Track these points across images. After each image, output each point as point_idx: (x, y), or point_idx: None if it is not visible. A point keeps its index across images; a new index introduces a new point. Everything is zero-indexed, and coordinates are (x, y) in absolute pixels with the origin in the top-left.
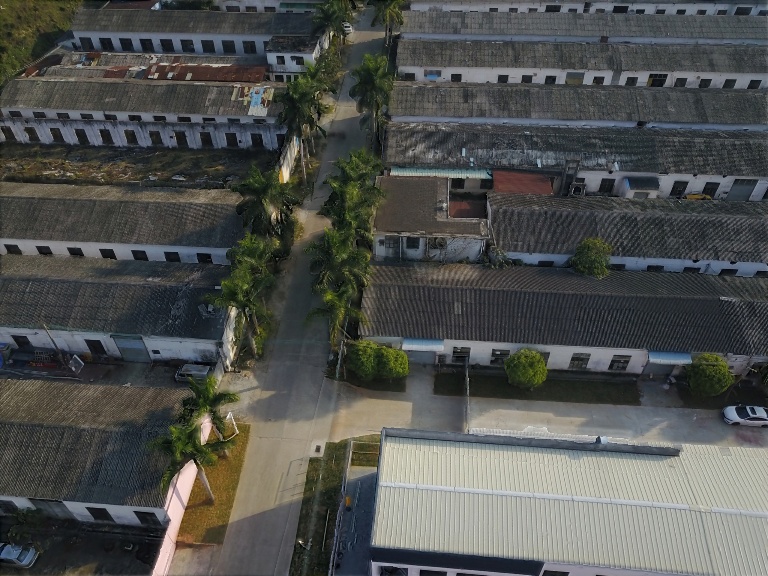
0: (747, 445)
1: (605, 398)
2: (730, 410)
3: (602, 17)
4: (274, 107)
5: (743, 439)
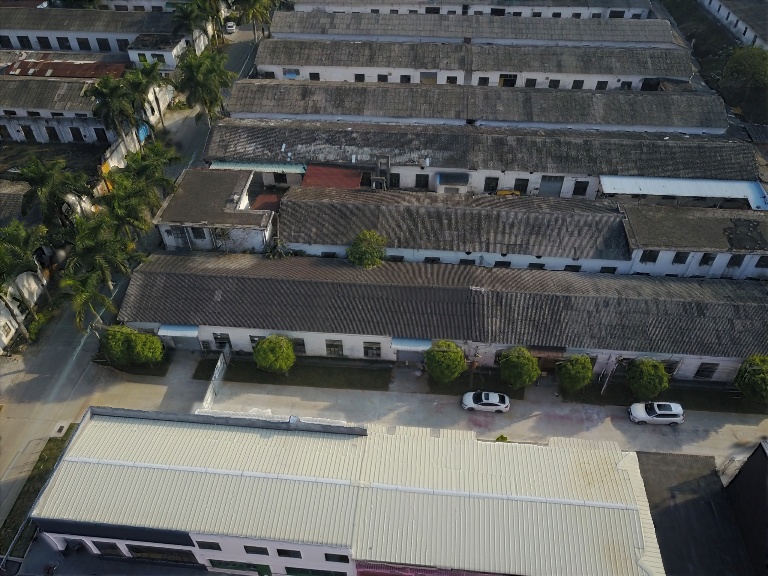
0: (476, 429)
1: (356, 384)
2: (468, 396)
3: (467, 19)
4: None
5: (474, 423)
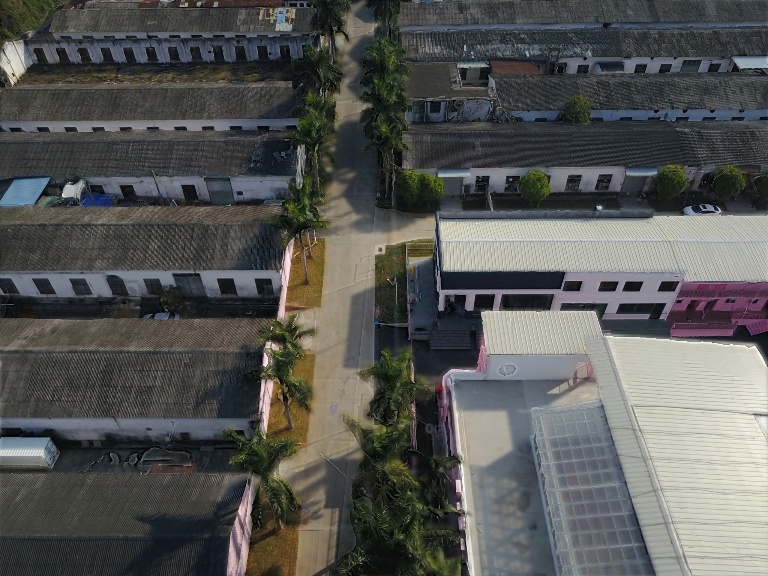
0: None
1: None
2: (687, 209)
3: None
4: (297, 24)
5: None
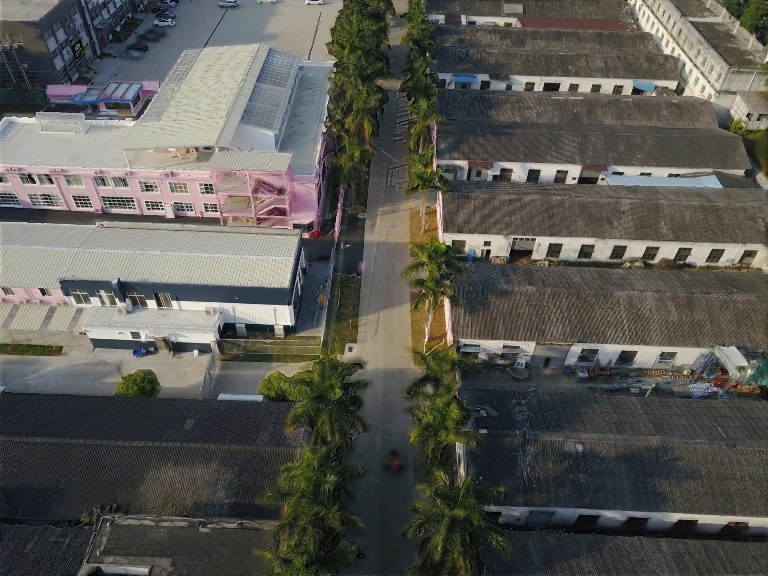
0: None
1: None
2: None
3: None
4: None
5: None
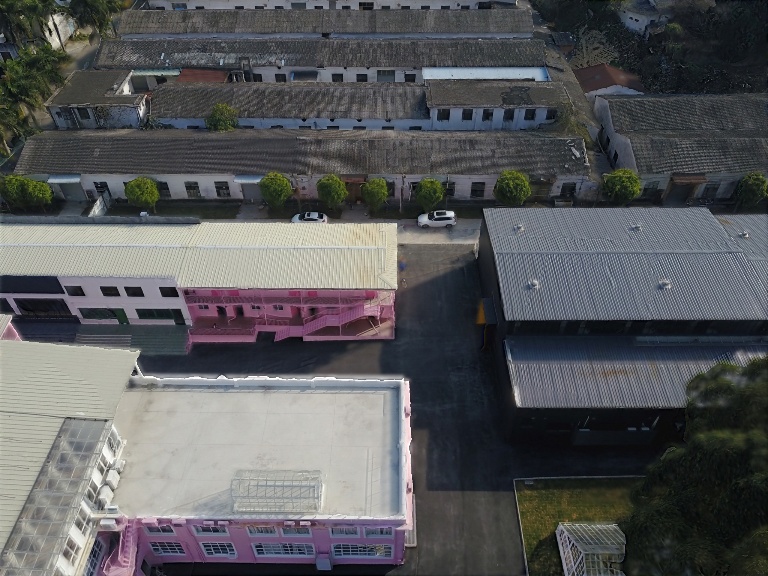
0: None
1: (210, 215)
2: (296, 216)
3: None
4: None
5: None
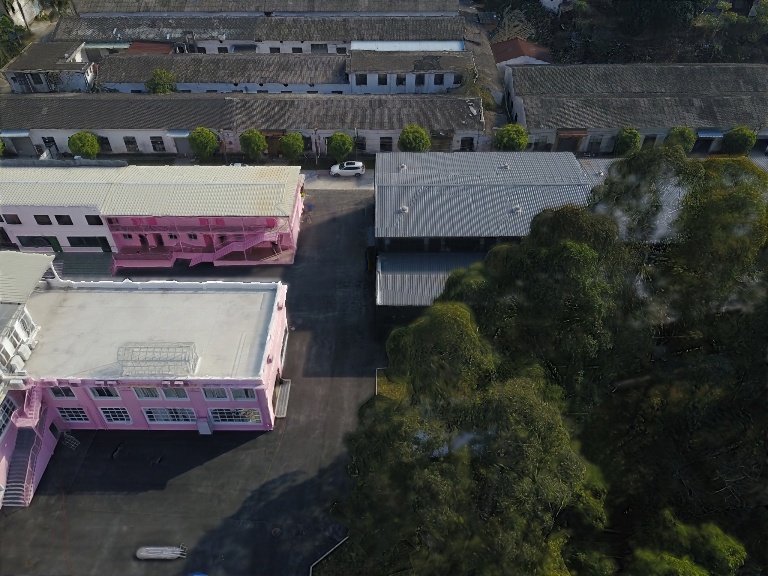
0: None
1: None
2: None
3: None
4: None
5: None
